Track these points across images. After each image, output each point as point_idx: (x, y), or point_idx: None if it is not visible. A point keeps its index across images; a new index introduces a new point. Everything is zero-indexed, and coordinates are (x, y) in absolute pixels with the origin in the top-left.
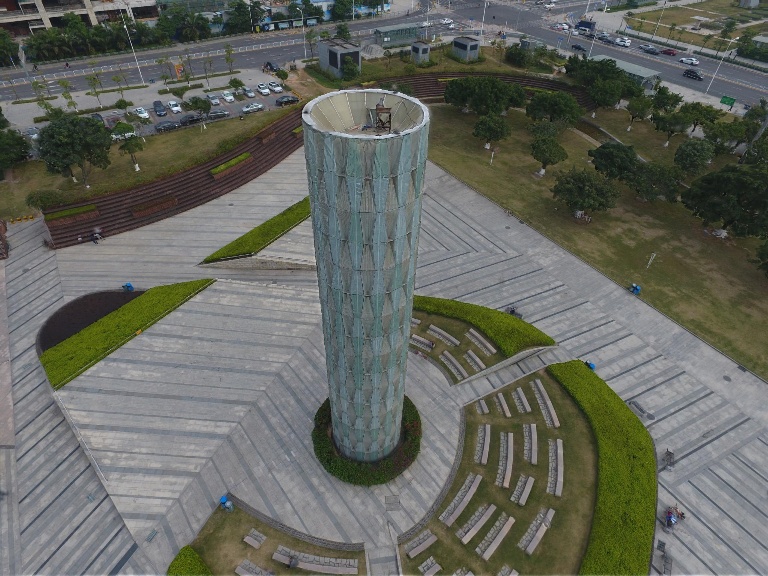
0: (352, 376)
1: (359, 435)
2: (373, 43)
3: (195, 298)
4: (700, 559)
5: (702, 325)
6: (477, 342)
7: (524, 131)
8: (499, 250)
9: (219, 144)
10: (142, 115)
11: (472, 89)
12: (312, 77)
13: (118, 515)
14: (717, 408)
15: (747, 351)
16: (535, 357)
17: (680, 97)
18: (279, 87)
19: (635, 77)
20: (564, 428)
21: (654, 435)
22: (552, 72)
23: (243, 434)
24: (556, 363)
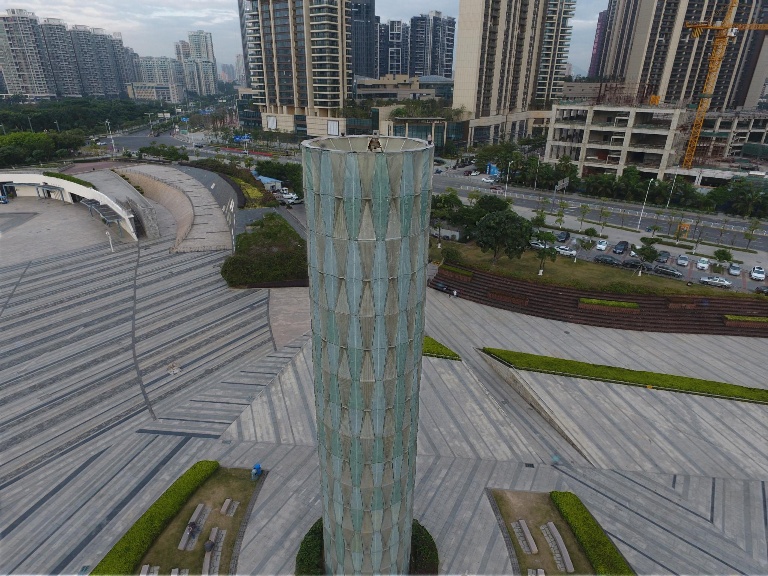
0: None
1: None
2: None
3: (433, 359)
4: None
5: None
6: None
7: None
8: None
9: (612, 282)
10: (599, 246)
11: None
12: None
13: (238, 416)
14: None
15: None
16: None
17: None
18: None
19: None
20: None
21: None
22: None
23: None
24: None
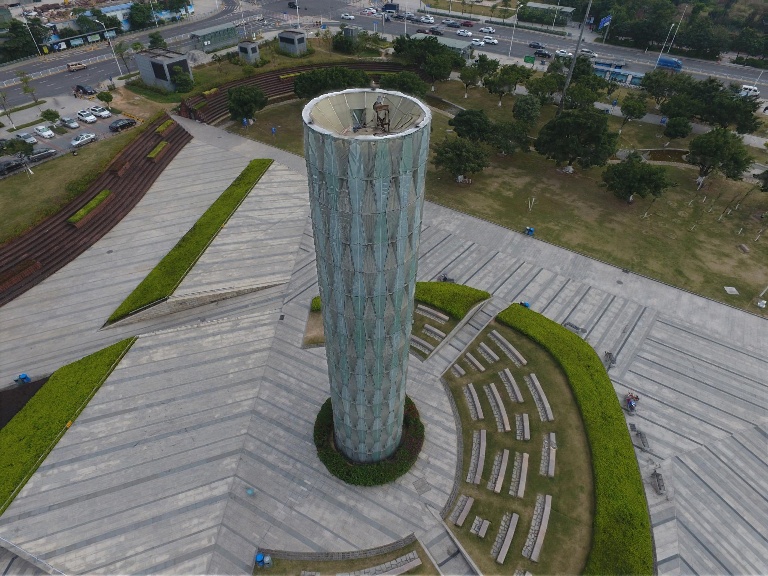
0: (371, 379)
1: (376, 436)
2: (192, 49)
3: (121, 364)
4: (660, 425)
5: (586, 246)
6: (429, 315)
7: None
8: None
9: (68, 187)
10: None
11: (323, 81)
12: (139, 94)
13: None
14: (623, 307)
15: (623, 257)
16: (480, 312)
17: (497, 62)
18: (105, 111)
19: (454, 50)
20: (531, 363)
21: (592, 344)
22: (380, 55)
23: (245, 485)
24: (501, 311)
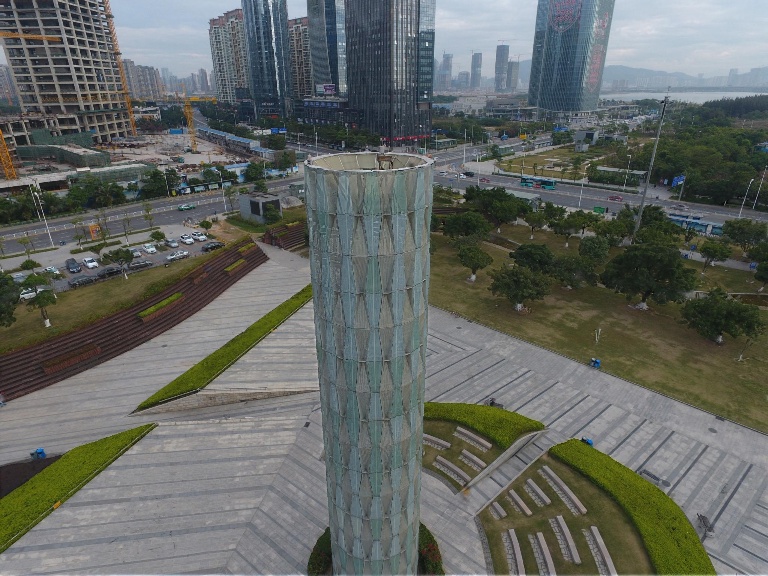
0: (367, 479)
1: (376, 570)
2: (289, 195)
3: (132, 450)
4: None
5: (667, 385)
6: (468, 440)
7: (445, 248)
8: (458, 348)
9: (147, 287)
10: None
11: None
12: (235, 226)
13: None
14: (719, 461)
15: (715, 402)
16: (531, 445)
17: (564, 209)
18: (203, 236)
19: (522, 200)
20: (592, 513)
21: (678, 502)
22: None
23: None
24: (556, 445)
